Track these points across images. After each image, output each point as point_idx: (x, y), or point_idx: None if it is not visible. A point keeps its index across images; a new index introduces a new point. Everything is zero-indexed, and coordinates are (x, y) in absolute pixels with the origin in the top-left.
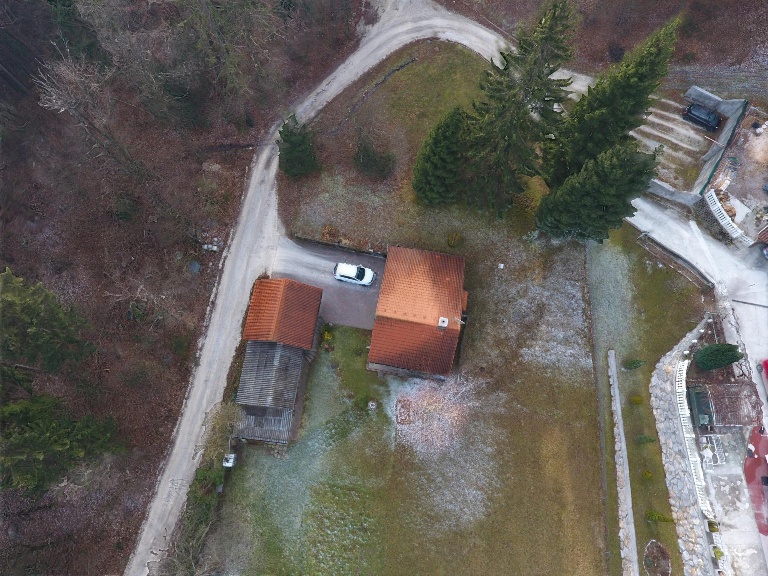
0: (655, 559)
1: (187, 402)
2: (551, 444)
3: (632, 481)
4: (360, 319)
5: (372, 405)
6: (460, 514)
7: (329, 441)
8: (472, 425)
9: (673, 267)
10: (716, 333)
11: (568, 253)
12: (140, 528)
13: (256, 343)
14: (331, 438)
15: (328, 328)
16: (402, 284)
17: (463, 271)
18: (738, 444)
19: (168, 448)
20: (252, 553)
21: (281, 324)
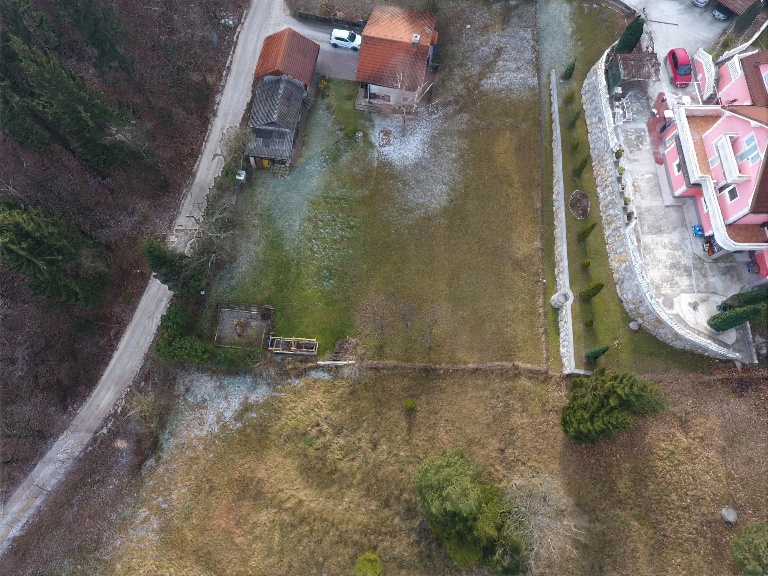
0: (578, 201)
1: (206, 144)
2: (503, 144)
3: (563, 153)
4: (351, 74)
5: (359, 133)
6: (428, 204)
7: (323, 165)
8: (440, 140)
9: (605, 5)
10: None
11: (522, 8)
12: (167, 238)
13: (264, 84)
14: (325, 162)
15: (324, 77)
16: (384, 22)
17: (435, 19)
18: (644, 109)
19: (190, 179)
20: (259, 249)
21: (285, 60)
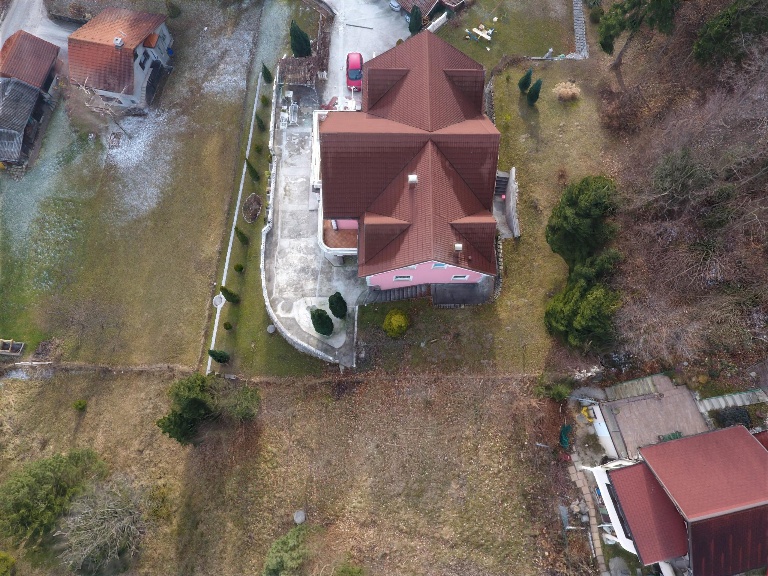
0: (251, 205)
1: None
2: (209, 147)
3: (250, 157)
4: None
5: (90, 135)
6: (140, 207)
7: (57, 166)
8: (160, 142)
9: (315, 8)
10: (323, 44)
11: (251, 11)
12: None
13: None
14: (59, 164)
15: (64, 79)
16: (103, 25)
17: (161, 22)
18: None
19: None
20: None
21: (11, 62)
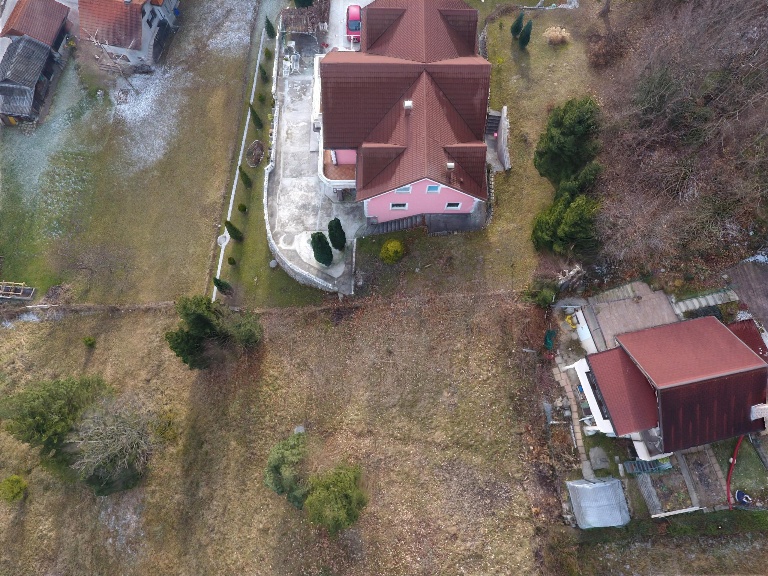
0: (254, 151)
1: None
2: (214, 100)
3: (253, 107)
4: None
5: (99, 92)
6: (147, 158)
7: (67, 122)
8: (166, 97)
9: None
10: None
11: None
12: None
13: (12, 44)
14: (68, 120)
15: (74, 39)
16: None
17: None
18: None
19: None
20: None
21: (23, 20)
